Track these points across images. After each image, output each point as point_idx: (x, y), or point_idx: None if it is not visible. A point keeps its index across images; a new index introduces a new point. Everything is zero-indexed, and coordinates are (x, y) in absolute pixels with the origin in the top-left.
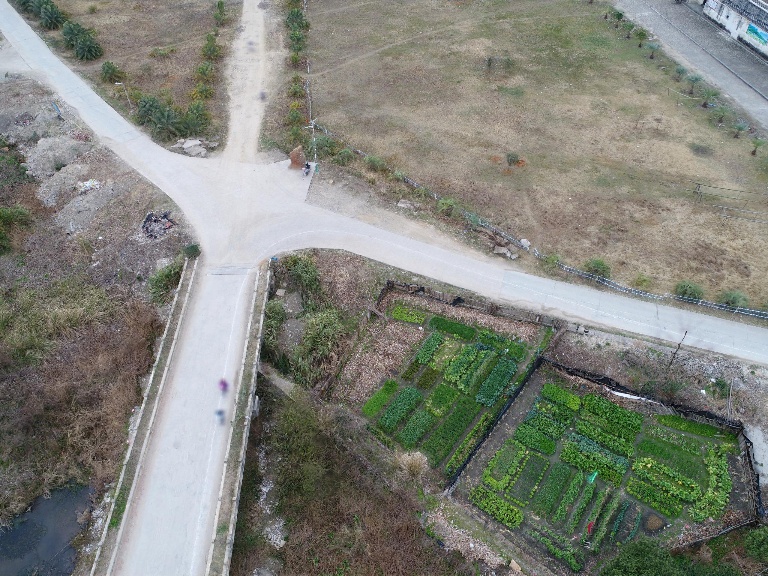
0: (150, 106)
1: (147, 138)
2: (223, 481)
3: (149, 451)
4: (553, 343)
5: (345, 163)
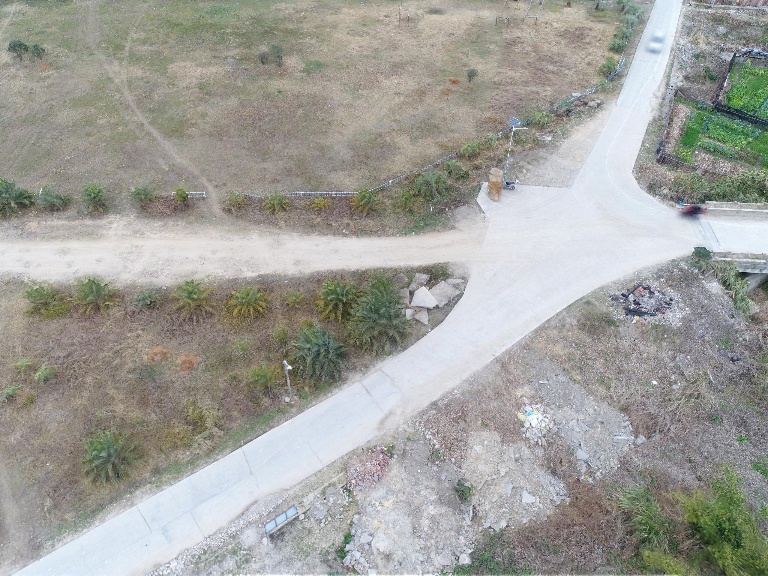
0: None
1: (393, 360)
2: None
3: None
4: None
5: None
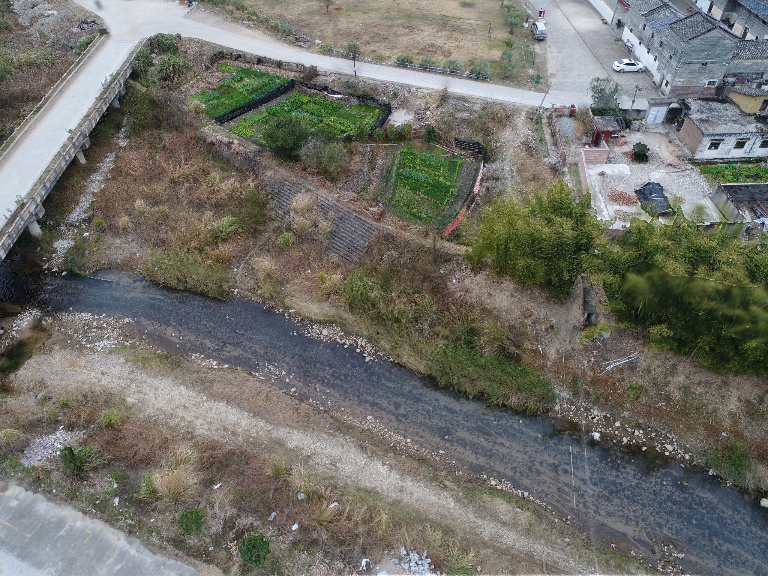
0: None
1: None
2: (92, 104)
3: (58, 98)
4: (304, 75)
5: None
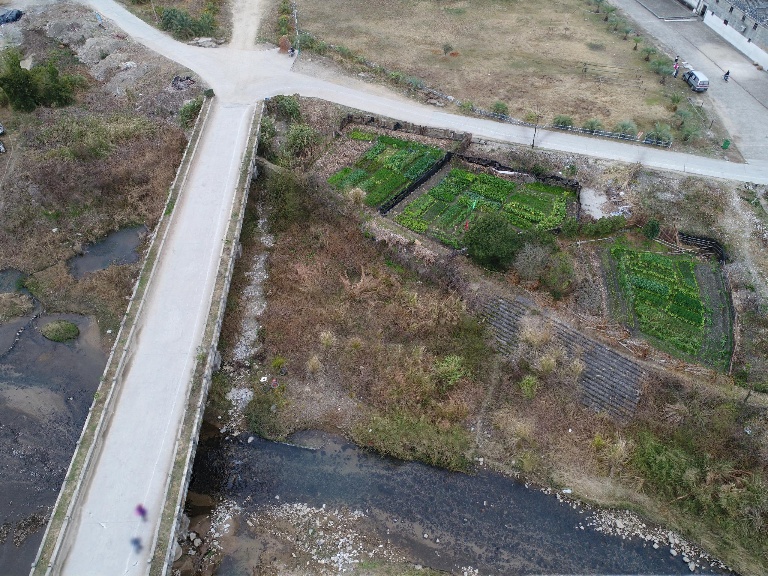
0: (172, 15)
1: (170, 38)
2: (234, 197)
3: (186, 187)
4: (460, 146)
5: (321, 53)
